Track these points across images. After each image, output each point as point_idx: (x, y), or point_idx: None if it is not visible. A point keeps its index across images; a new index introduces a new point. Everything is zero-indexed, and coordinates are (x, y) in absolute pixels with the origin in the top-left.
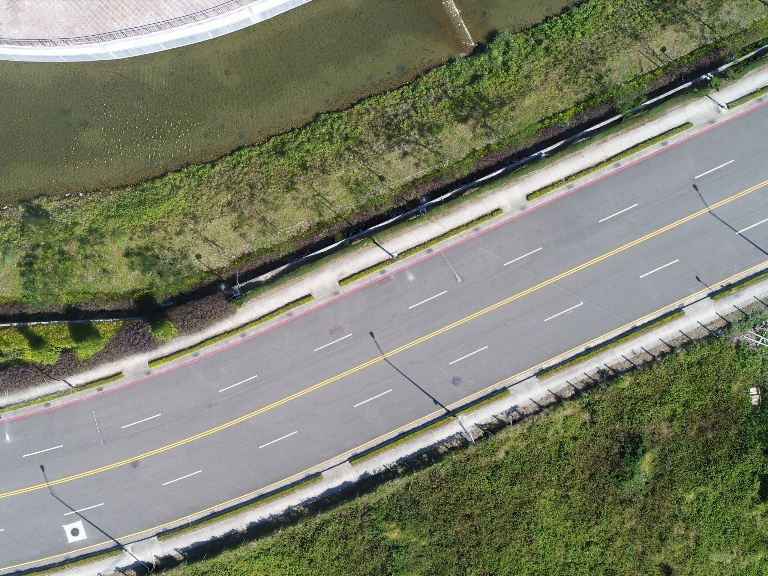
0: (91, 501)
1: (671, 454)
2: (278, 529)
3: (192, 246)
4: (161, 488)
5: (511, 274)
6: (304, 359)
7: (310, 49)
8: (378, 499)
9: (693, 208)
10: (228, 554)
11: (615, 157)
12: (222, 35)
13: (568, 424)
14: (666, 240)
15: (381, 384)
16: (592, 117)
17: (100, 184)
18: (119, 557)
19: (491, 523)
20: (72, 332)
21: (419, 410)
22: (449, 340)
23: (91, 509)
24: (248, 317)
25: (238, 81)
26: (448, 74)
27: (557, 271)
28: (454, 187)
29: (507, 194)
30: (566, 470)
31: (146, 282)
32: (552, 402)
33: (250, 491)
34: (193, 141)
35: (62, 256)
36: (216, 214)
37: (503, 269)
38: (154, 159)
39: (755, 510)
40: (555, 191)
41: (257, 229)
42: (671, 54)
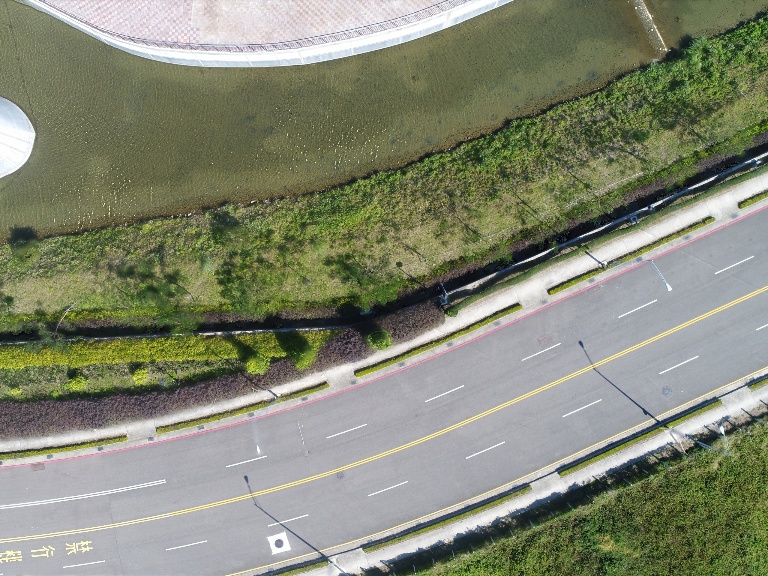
0: (296, 512)
1: None
2: (489, 541)
3: (393, 254)
4: (367, 499)
5: (722, 283)
6: (512, 369)
7: (499, 54)
8: (590, 511)
9: None
10: (438, 566)
11: None
12: (410, 40)
13: None
14: None
15: (590, 394)
16: None
17: (285, 191)
18: (324, 569)
19: (704, 535)
20: (281, 341)
21: (628, 420)
22: (659, 349)
23: (295, 520)
24: (455, 326)
25: (425, 87)
26: (644, 80)
27: None
28: (662, 194)
29: (718, 202)
30: None
31: (346, 290)
32: (764, 412)
33: (457, 502)
34: (380, 147)
35: (261, 264)
36: (417, 222)
37: (714, 278)
38: (340, 165)
39: None
40: (767, 199)
41: (459, 237)
42: None
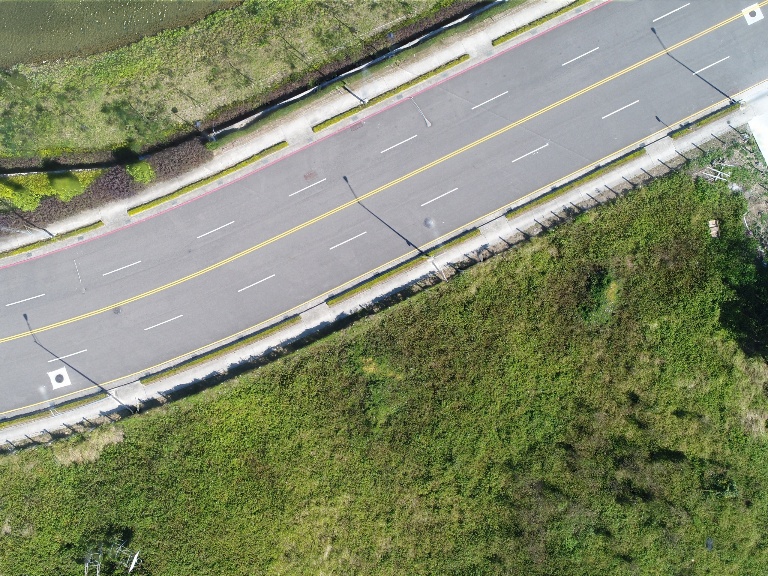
0: (74, 348)
1: (635, 285)
2: (258, 367)
3: (168, 100)
4: (143, 333)
5: (479, 117)
6: (280, 204)
7: None
8: (355, 336)
9: (652, 50)
10: (210, 393)
11: (576, 2)
12: None
13: (536, 259)
14: (627, 82)
15: (355, 227)
16: None
17: (76, 51)
18: (103, 401)
19: (464, 357)
20: (51, 180)
21: (393, 251)
22: (420, 182)
23: (75, 355)
24: (224, 164)
25: None
26: None
27: (523, 114)
28: None
29: (473, 40)
30: (535, 303)
31: (124, 136)
32: (521, 240)
33: (230, 334)
34: (167, 7)
35: (40, 112)
36: (191, 69)
37: (471, 113)
38: (129, 25)
39: (716, 335)
40: (519, 37)
41: (231, 82)
42: None
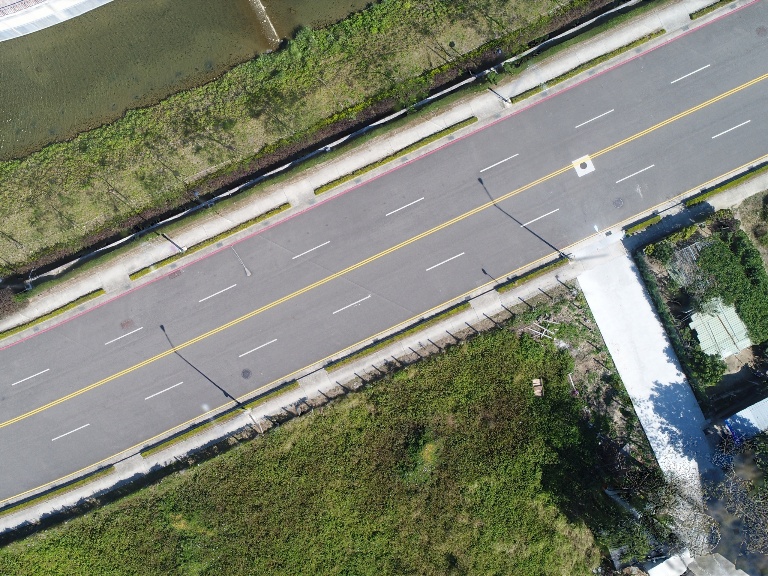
0: None
1: (455, 445)
2: (67, 520)
3: None
4: None
5: (299, 267)
6: (96, 352)
7: (119, 46)
8: (166, 490)
9: (478, 201)
10: (18, 545)
11: (400, 151)
12: (32, 32)
13: (354, 415)
14: (452, 233)
15: (172, 377)
16: (379, 112)
17: None
18: None
19: (279, 514)
20: None
21: (210, 402)
22: (239, 333)
23: None
24: (40, 311)
25: (49, 78)
26: (251, 70)
27: (345, 264)
28: None
29: (295, 188)
30: (352, 461)
31: None
32: (340, 394)
33: (43, 483)
34: (5, 137)
35: None
36: (14, 209)
37: (292, 262)
38: None
39: (536, 500)
40: (343, 185)
41: (54, 224)
42: (460, 49)
